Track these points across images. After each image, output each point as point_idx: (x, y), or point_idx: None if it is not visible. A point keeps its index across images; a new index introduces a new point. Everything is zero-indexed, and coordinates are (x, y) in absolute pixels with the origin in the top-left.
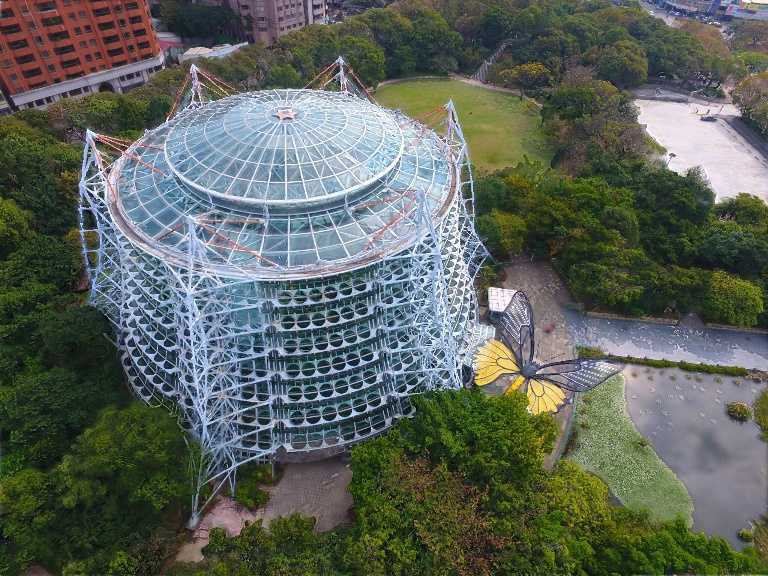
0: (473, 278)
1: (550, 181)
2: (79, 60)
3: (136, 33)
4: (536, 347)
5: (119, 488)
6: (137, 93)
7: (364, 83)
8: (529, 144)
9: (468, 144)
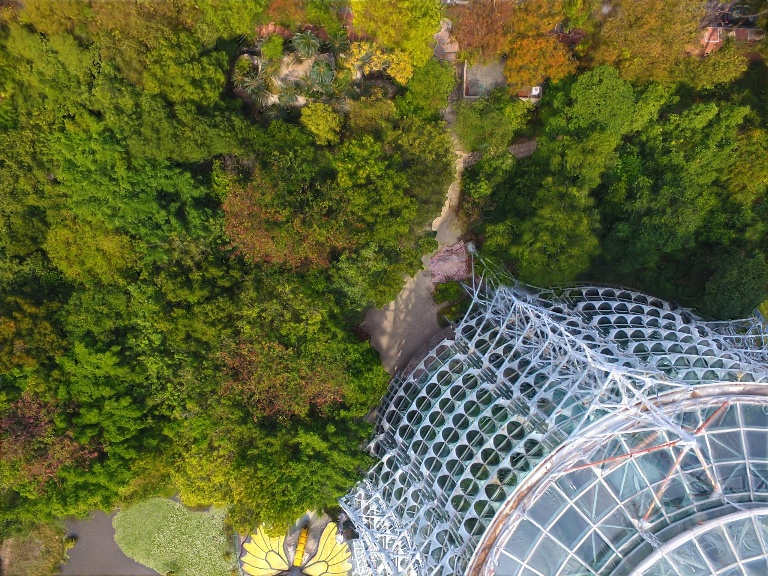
0: None
1: None
2: None
3: None
4: None
5: (533, 218)
6: None
7: None
8: None
9: None
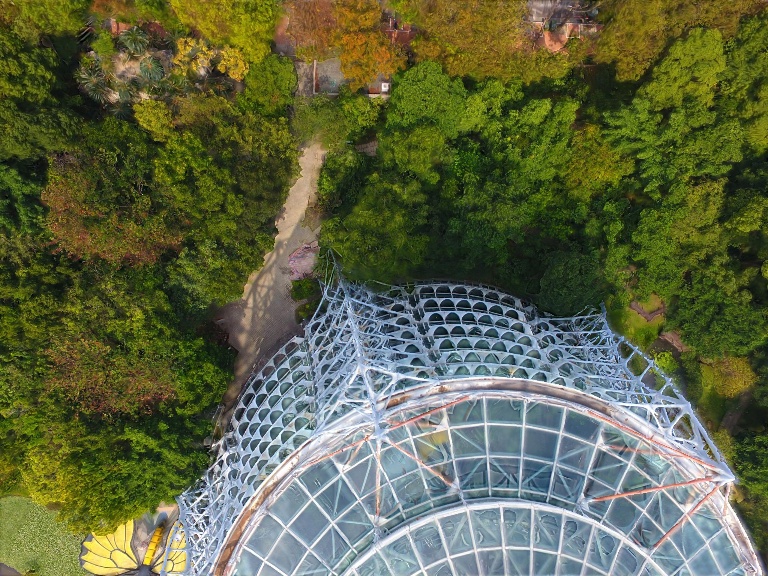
0: None
1: None
2: None
3: None
4: None
5: None
6: None
7: None
8: None
9: None
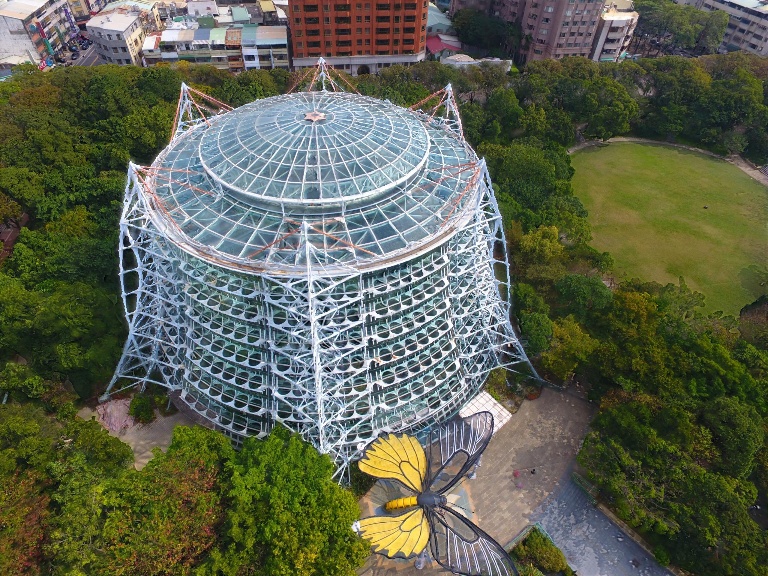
0: (481, 372)
1: (698, 326)
2: (351, 42)
3: (406, 30)
4: (458, 483)
5: None
6: (363, 78)
7: (592, 131)
8: (754, 275)
9: (661, 239)
